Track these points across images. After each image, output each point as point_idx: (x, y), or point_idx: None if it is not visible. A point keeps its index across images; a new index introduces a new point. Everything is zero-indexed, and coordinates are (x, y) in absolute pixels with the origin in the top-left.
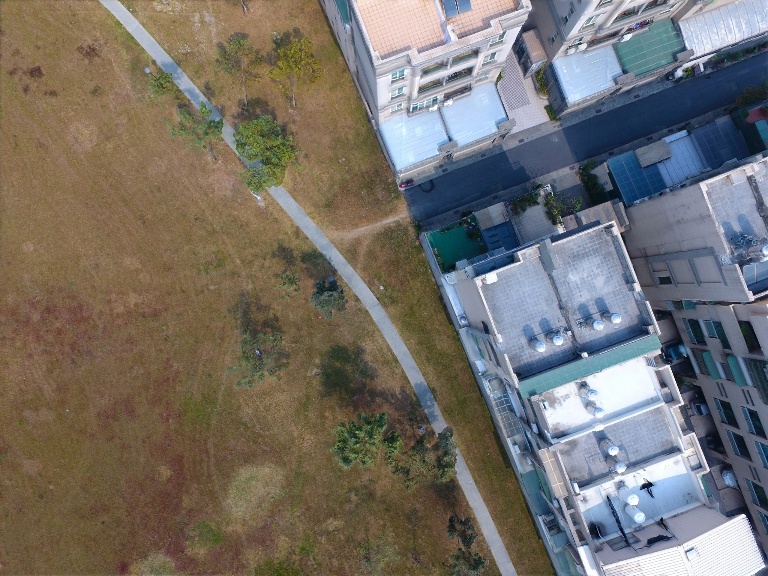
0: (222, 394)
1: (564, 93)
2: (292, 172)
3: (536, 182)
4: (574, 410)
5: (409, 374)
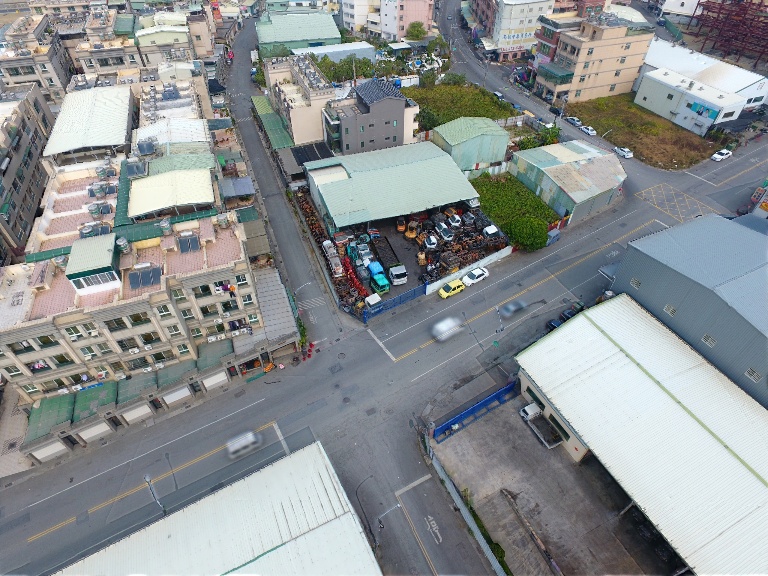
0: None
1: None
2: None
3: None
4: None
5: None
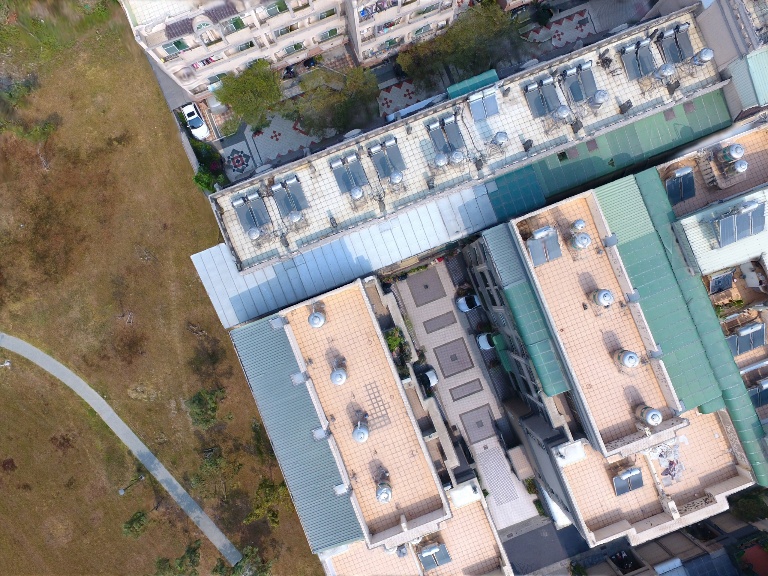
0: None
1: (552, 515)
2: (274, 566)
3: None
4: None
5: None
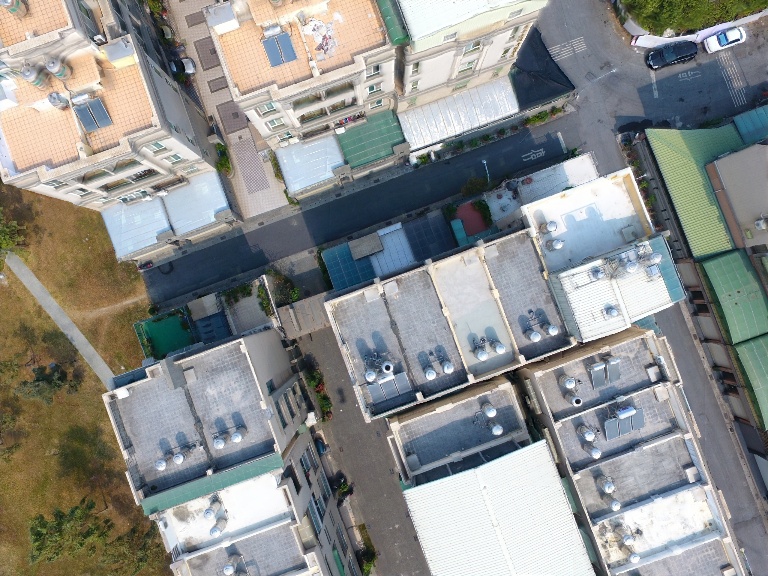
0: None
1: (285, 182)
2: (36, 251)
3: (275, 265)
4: (207, 524)
5: None
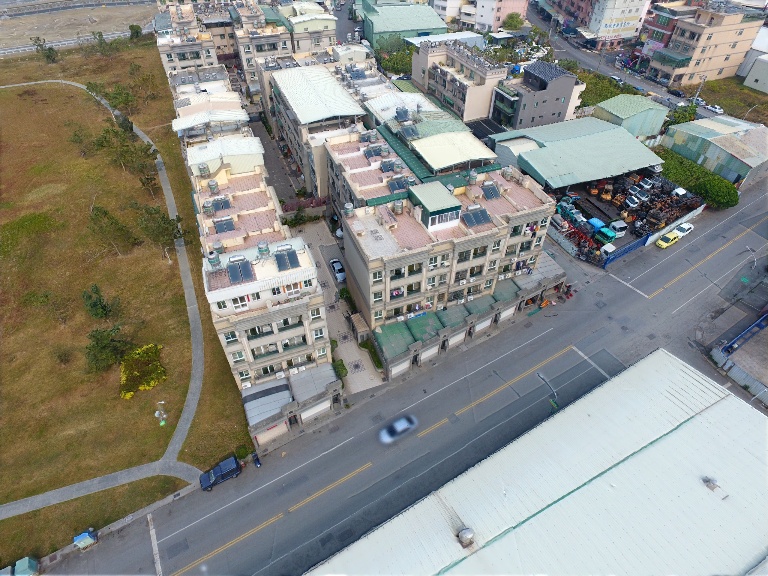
0: None
1: None
2: None
3: None
4: None
5: None
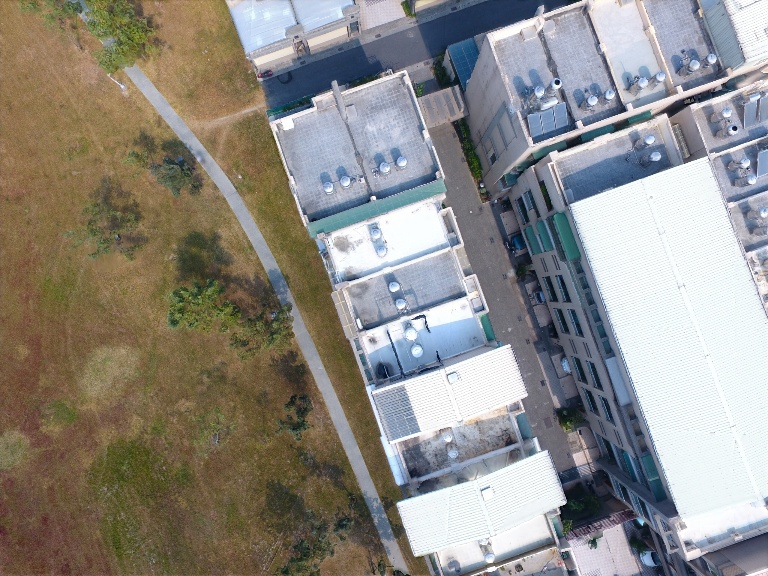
0: (81, 276)
1: None
2: (156, 63)
3: None
4: (366, 255)
5: (263, 261)
